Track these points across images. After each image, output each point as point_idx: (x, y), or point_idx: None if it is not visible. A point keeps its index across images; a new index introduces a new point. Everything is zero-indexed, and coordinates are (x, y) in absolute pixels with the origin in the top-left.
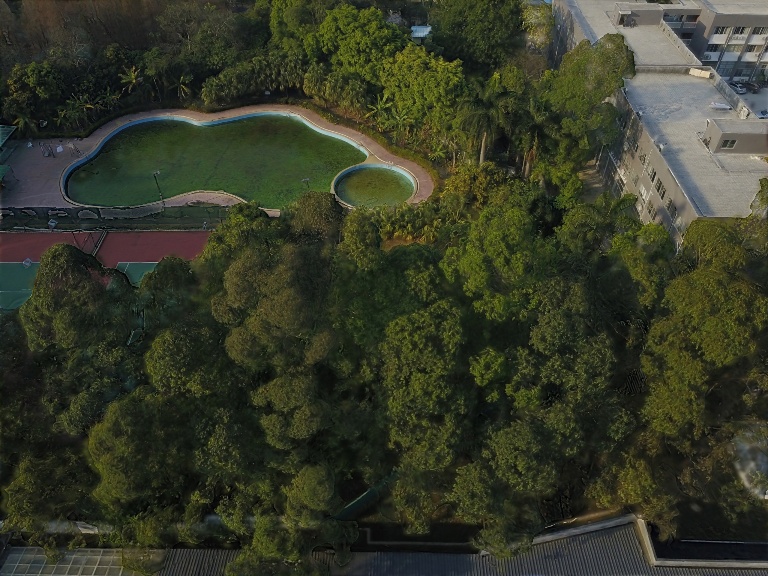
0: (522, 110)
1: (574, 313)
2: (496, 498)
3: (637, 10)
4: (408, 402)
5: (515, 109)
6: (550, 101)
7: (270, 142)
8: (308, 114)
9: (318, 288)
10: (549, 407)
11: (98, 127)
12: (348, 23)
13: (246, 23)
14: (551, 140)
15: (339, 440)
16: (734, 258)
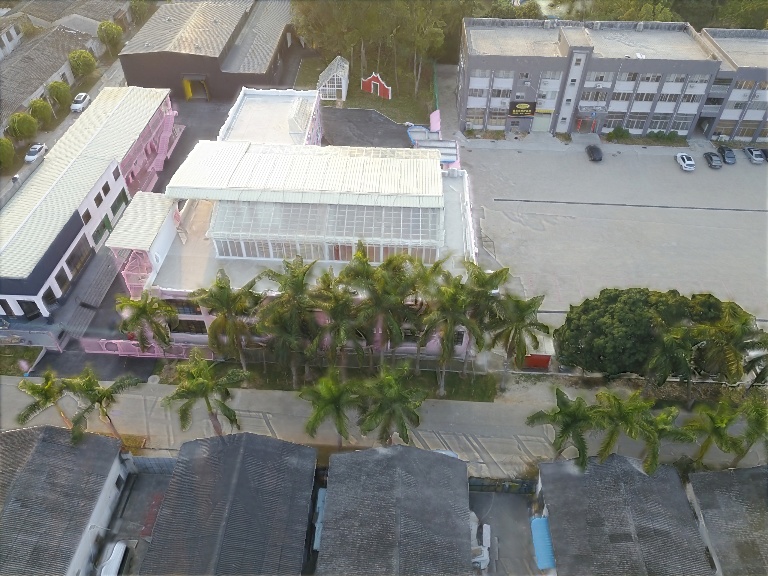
0: None
1: None
2: None
3: None
4: None
5: None
6: None
7: None
8: None
9: None
10: None
11: None
12: None
13: None
14: None
15: None
16: None
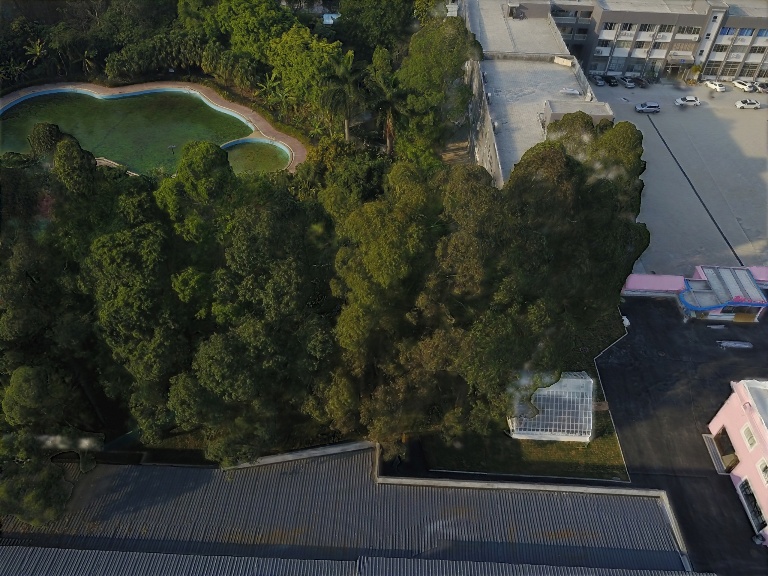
0: (375, 87)
1: (261, 237)
2: (211, 409)
3: (525, 3)
4: (112, 312)
5: (370, 86)
6: (398, 78)
7: (164, 116)
8: (207, 92)
9: (19, 203)
10: (245, 323)
11: (0, 96)
12: (239, 4)
13: (154, 3)
14: (404, 117)
15: (60, 349)
16: (416, 195)
